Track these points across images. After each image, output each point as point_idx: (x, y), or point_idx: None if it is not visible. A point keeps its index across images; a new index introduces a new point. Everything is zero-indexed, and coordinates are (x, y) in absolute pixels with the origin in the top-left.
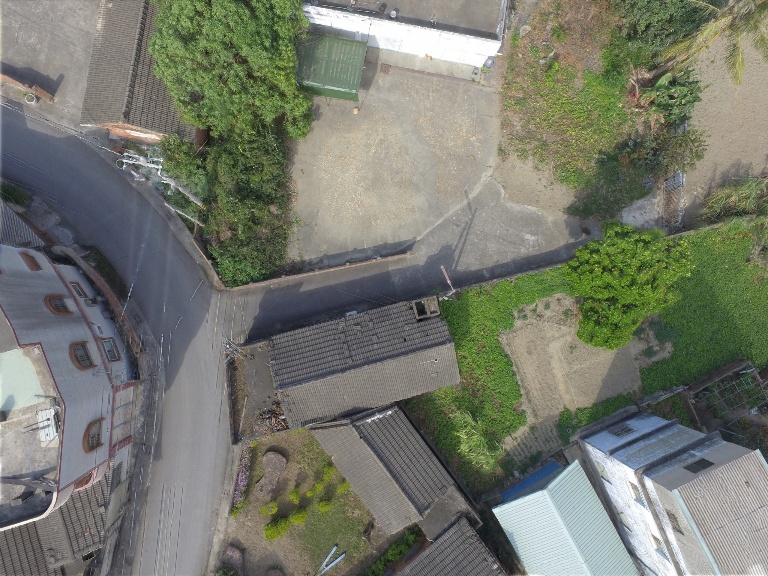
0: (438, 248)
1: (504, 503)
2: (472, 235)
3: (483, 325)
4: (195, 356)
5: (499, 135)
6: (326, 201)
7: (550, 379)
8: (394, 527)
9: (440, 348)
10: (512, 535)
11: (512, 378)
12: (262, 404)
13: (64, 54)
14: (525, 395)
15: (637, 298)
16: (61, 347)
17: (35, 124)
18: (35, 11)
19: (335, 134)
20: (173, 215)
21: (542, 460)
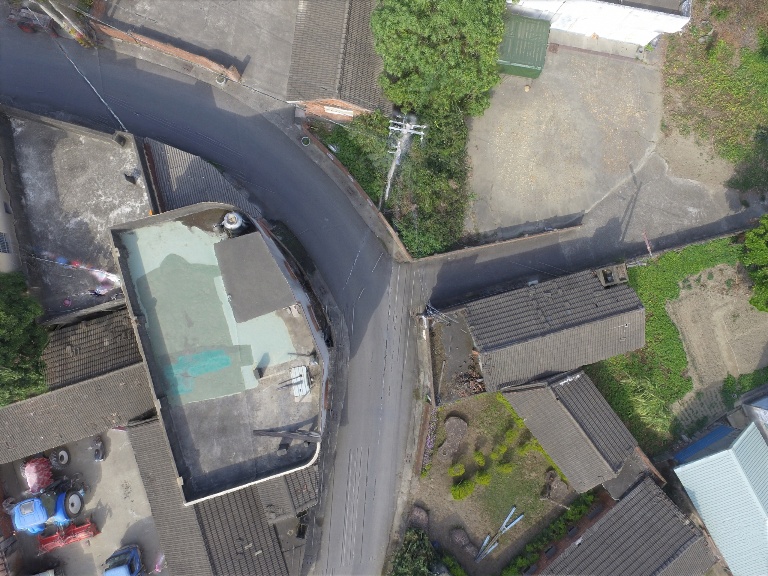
0: (606, 221)
1: (686, 463)
2: (638, 208)
3: (651, 295)
4: (378, 325)
5: (661, 111)
6: (500, 176)
7: (714, 347)
8: (586, 486)
9: (633, 313)
10: (694, 494)
11: (680, 345)
12: (458, 368)
13: (250, 36)
14: (691, 362)
15: None
16: (305, 308)
17: (223, 104)
18: None
19: (507, 111)
20: (353, 190)
21: (708, 425)
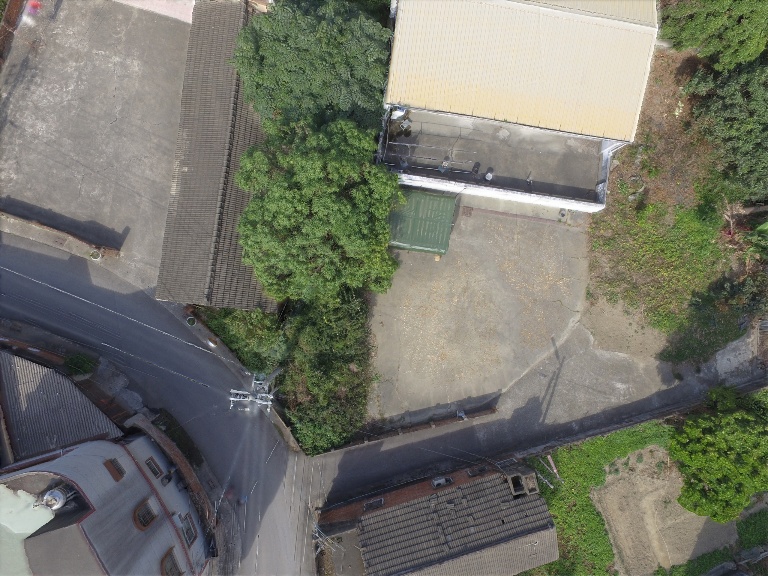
0: (525, 401)
1: None
2: (560, 386)
3: (573, 482)
4: (272, 522)
5: (587, 278)
6: (407, 355)
7: (643, 536)
8: None
9: (542, 532)
10: None
11: (605, 538)
12: None
13: (130, 205)
14: (618, 554)
15: (757, 487)
16: (154, 572)
17: (100, 280)
18: (99, 161)
19: (416, 283)
20: None
21: None
